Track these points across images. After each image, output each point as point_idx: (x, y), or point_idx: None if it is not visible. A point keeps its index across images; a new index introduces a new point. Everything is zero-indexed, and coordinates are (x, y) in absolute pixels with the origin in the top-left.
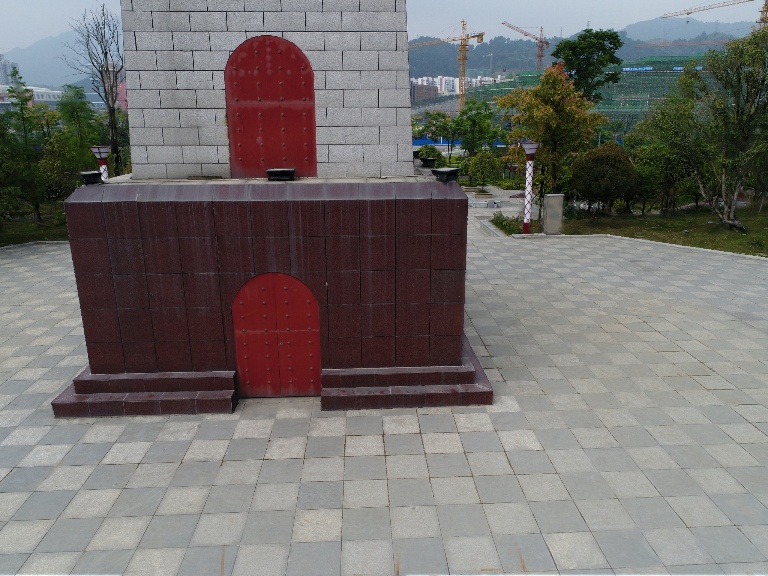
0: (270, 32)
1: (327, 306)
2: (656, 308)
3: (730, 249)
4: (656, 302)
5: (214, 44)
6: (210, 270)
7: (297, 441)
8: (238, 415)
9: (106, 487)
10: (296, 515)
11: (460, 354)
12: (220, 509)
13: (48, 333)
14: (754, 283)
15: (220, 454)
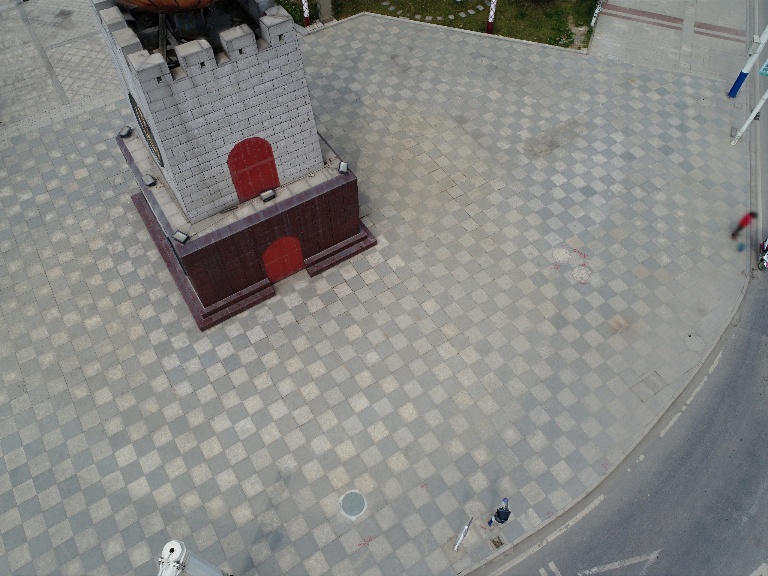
0: (246, 137)
1: (303, 239)
2: (419, 125)
3: (444, 11)
4: (418, 117)
5: None
6: (251, 250)
7: (316, 299)
8: (279, 295)
9: (268, 352)
10: (344, 332)
11: (359, 230)
12: (317, 341)
13: (107, 279)
14: (462, 73)
15: (293, 319)
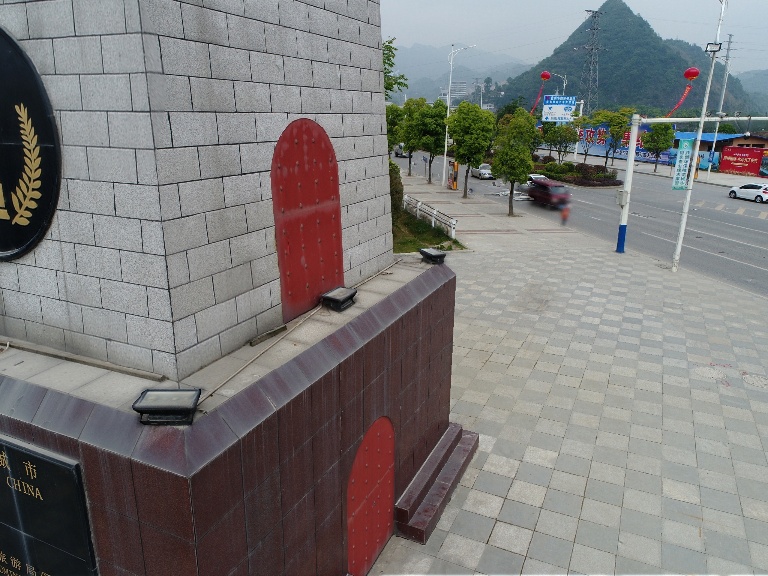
0: (306, 114)
1: (400, 432)
2: None
3: None
4: None
5: (260, 132)
6: (334, 460)
7: None
8: None
9: None
10: None
11: (448, 417)
12: None
13: None
14: None
15: None
